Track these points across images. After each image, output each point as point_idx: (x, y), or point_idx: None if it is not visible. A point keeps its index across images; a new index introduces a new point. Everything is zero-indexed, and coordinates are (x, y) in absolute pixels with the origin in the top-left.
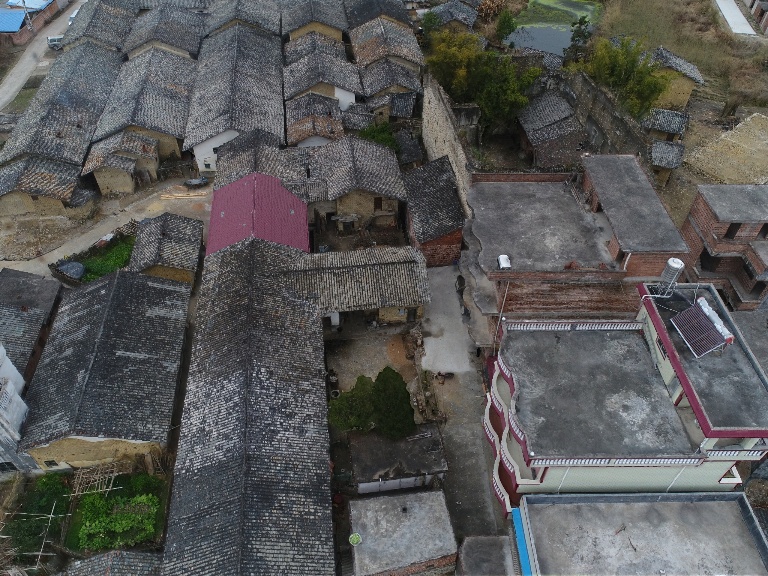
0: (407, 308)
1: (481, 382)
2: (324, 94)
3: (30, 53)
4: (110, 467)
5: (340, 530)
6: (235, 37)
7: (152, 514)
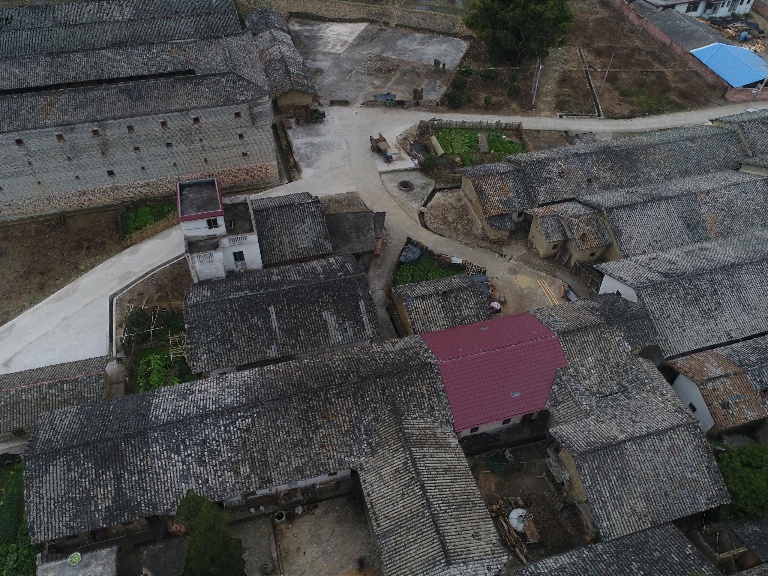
0: None
1: None
2: None
3: (720, 111)
4: None
5: (124, 554)
6: None
7: None
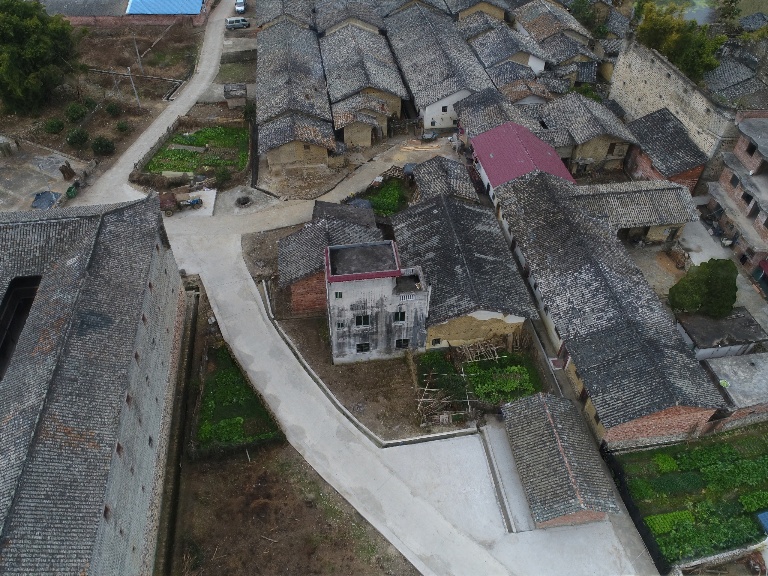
0: (672, 228)
1: (751, 284)
2: (519, 62)
3: (211, 33)
4: (487, 343)
5: None
6: (423, 15)
7: (527, 379)
